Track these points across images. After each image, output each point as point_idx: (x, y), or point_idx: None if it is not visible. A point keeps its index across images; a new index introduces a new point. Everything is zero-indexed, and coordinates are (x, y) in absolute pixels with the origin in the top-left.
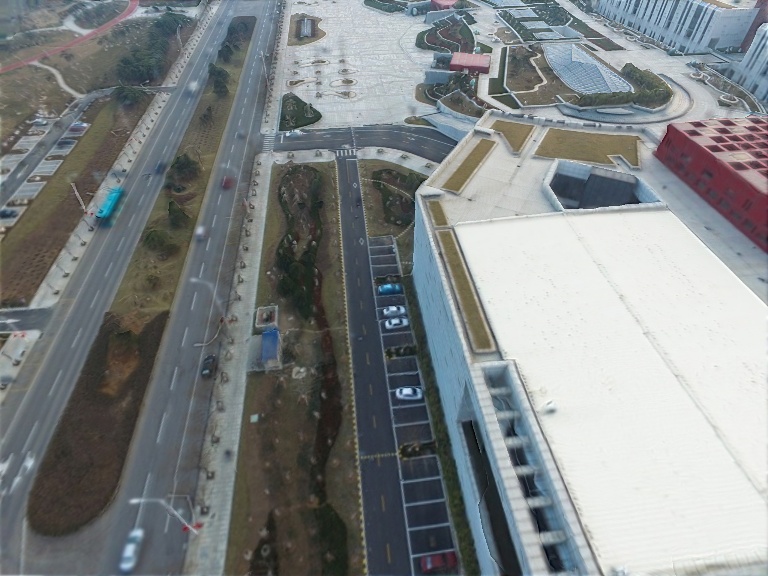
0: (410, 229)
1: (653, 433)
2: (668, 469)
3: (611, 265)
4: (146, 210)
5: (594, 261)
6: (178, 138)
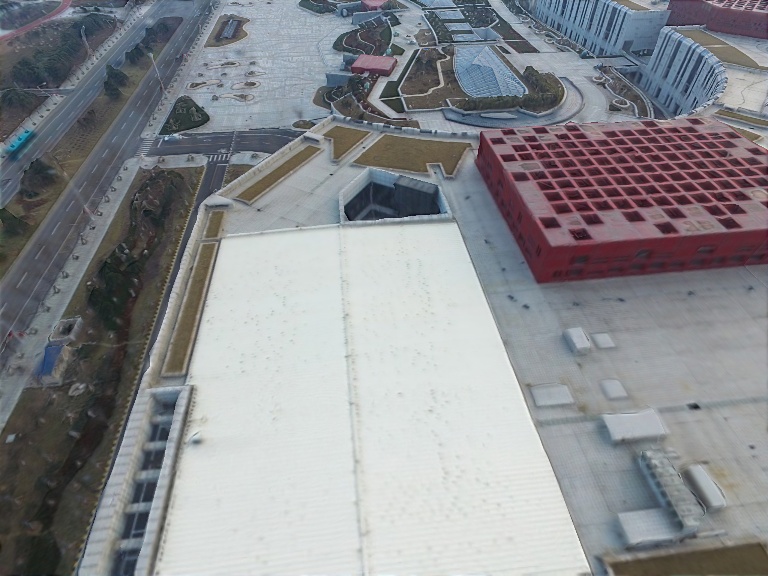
0: None
1: (284, 468)
2: (274, 510)
3: (356, 281)
4: None
5: (341, 277)
6: (54, 142)
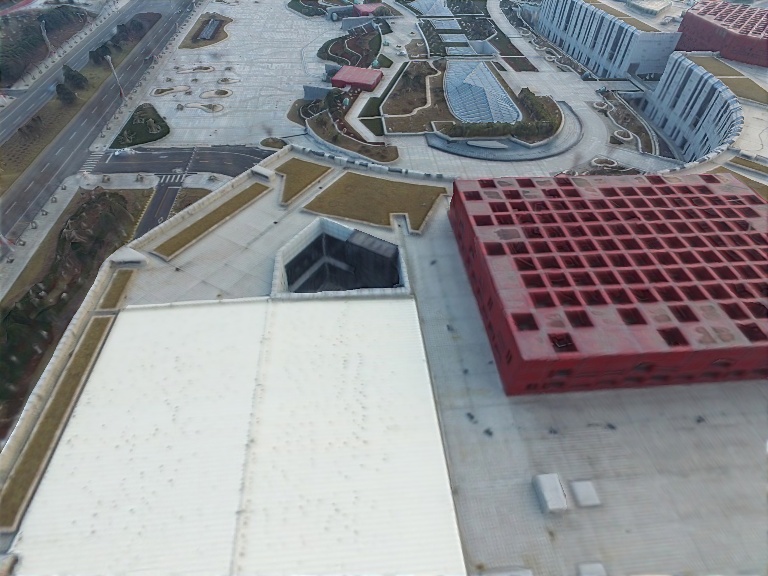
0: None
1: None
2: None
3: (274, 386)
4: None
5: (256, 378)
6: None
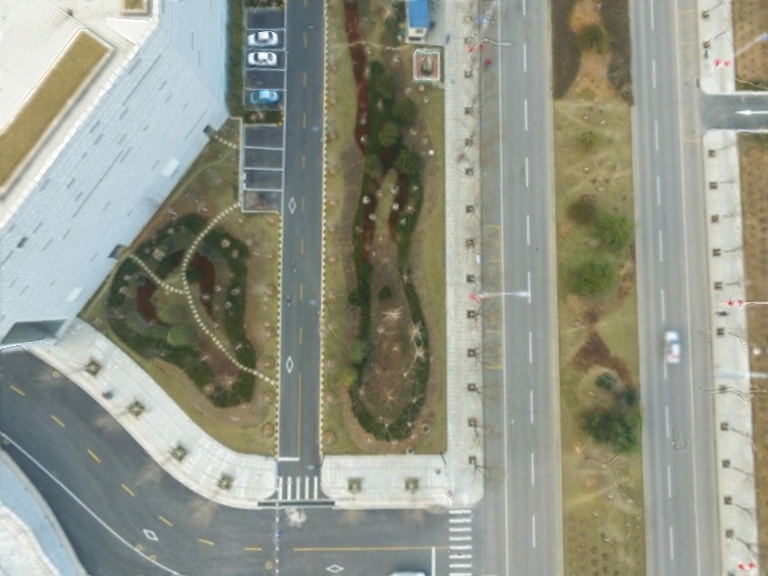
0: (210, 220)
1: None
2: None
3: None
4: (648, 329)
5: None
6: None
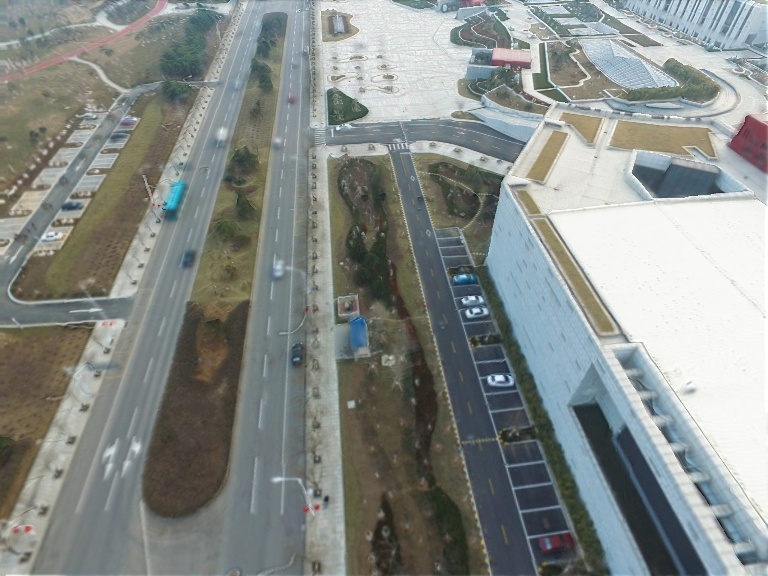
0: (475, 221)
1: None
2: None
3: (715, 252)
4: (209, 202)
5: (697, 248)
6: (229, 132)
